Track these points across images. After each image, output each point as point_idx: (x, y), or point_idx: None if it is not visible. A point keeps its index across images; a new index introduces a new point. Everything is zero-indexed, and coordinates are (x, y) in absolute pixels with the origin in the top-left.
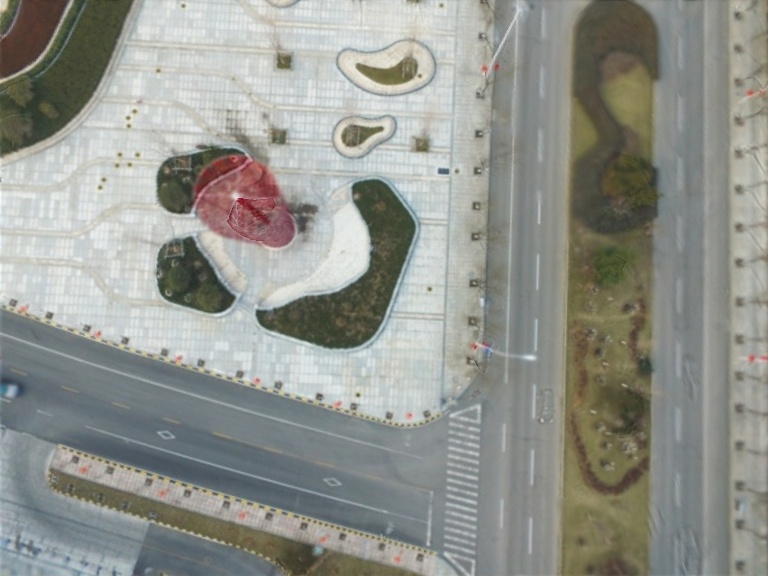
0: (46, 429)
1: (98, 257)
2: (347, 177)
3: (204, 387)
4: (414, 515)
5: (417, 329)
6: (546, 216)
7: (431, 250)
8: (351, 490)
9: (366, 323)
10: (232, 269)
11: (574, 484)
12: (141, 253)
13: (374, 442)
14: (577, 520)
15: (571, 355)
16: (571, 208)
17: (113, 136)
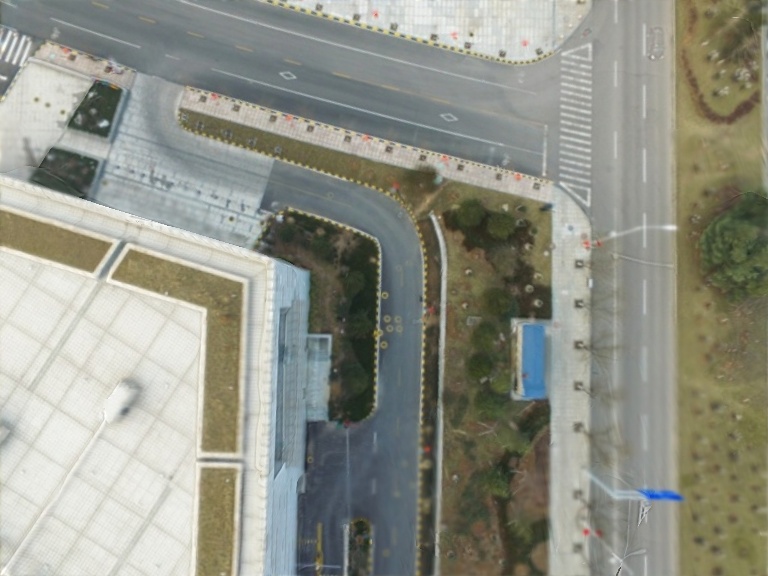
0: (174, 72)
1: None
2: None
3: (323, 30)
4: (529, 147)
5: None
6: None
7: None
8: (467, 125)
9: None
10: None
11: (686, 115)
12: None
13: (488, 79)
14: (691, 147)
15: None
16: None
17: None
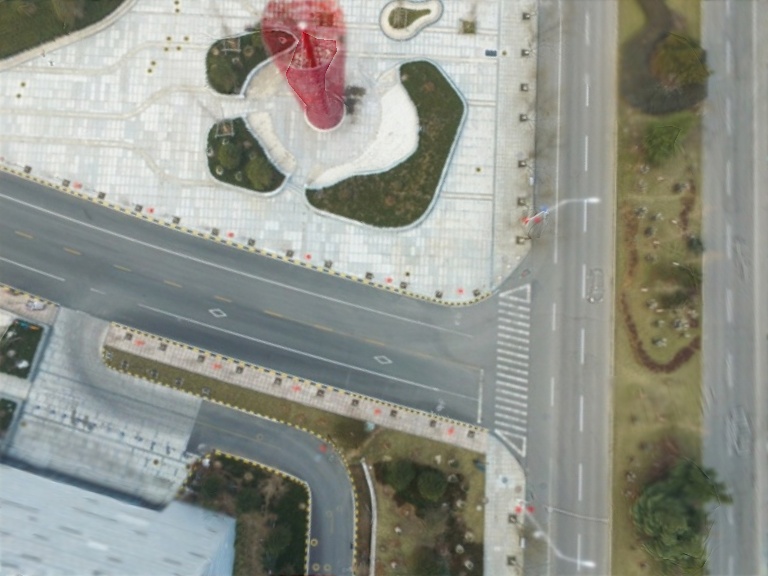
0: (100, 307)
1: (149, 139)
2: (395, 59)
3: (255, 266)
4: (464, 393)
5: (466, 209)
6: (594, 98)
7: (479, 131)
8: (401, 368)
9: (415, 202)
10: (281, 150)
11: (625, 362)
12: (191, 135)
13: (424, 320)
14: (628, 397)
15: (621, 235)
16: (620, 89)
17: (162, 20)
